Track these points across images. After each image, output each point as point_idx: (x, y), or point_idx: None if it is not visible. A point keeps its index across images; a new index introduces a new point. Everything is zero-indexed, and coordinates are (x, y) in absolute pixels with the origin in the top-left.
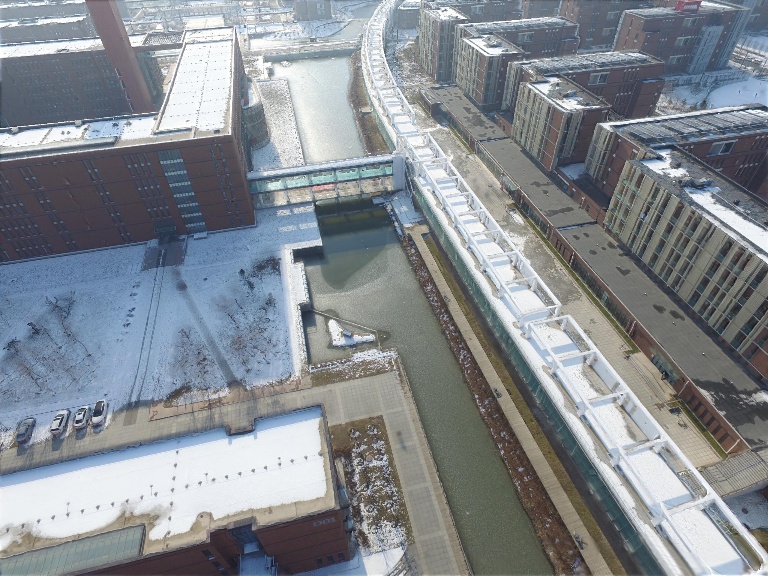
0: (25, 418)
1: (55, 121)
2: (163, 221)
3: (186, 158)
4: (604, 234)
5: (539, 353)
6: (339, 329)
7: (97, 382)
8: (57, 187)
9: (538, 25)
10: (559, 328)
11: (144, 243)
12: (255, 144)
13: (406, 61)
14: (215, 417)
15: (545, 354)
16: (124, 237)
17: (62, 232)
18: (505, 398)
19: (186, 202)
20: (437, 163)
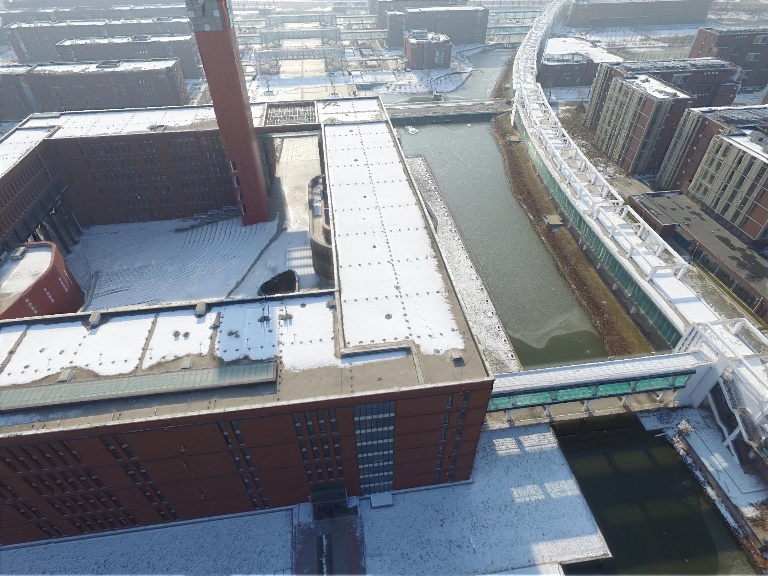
0: None
1: (136, 214)
2: (327, 483)
3: (401, 411)
4: None
5: None
6: None
7: None
8: (163, 455)
9: None
10: None
11: (287, 509)
12: None
13: (572, 137)
14: None
15: None
16: (256, 502)
17: (157, 503)
18: None
19: (374, 461)
20: None
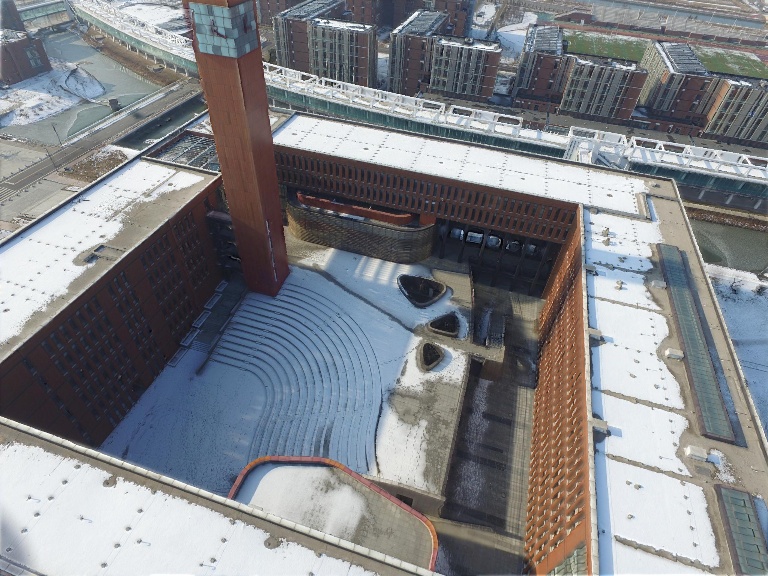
0: None
1: (118, 408)
2: None
3: None
4: None
5: None
6: None
7: None
8: None
9: None
10: None
11: None
12: None
13: None
14: None
15: None
16: None
17: None
18: None
19: None
20: None
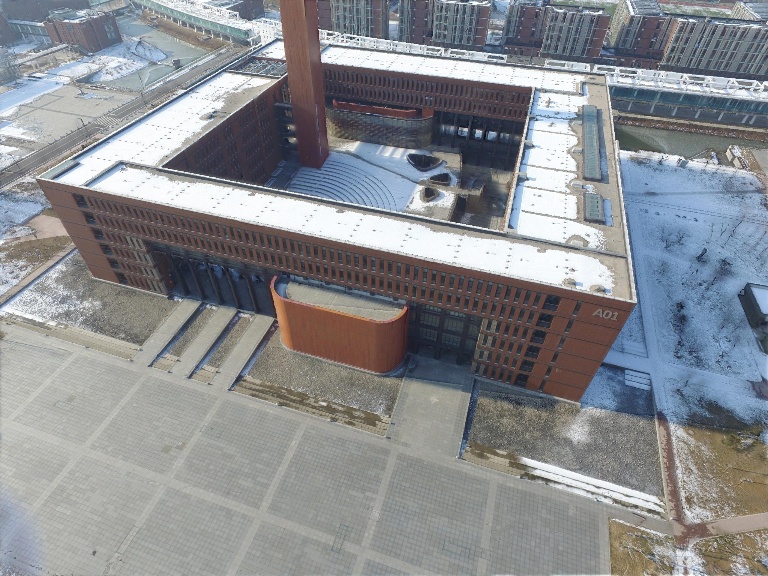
0: None
1: None
2: None
3: None
4: None
5: None
6: (704, 159)
7: (759, 236)
8: None
9: None
10: None
11: None
12: None
13: None
14: None
15: None
16: None
17: None
18: None
19: None
20: None
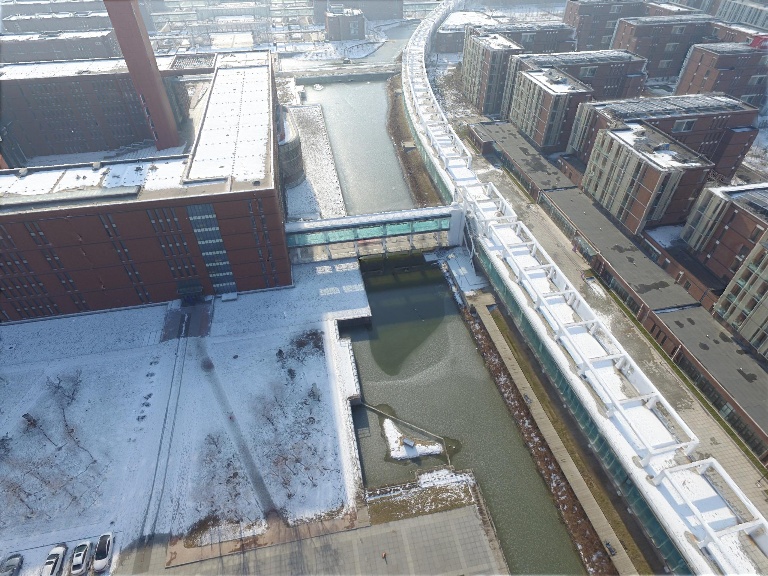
0: (10, 555)
1: (72, 147)
2: (188, 281)
3: (220, 213)
4: (713, 321)
5: (676, 510)
6: (397, 434)
7: (102, 503)
8: (68, 243)
9: (602, 59)
10: (694, 470)
11: (164, 304)
12: (289, 182)
13: (448, 89)
14: (249, 566)
15: (684, 512)
16: (142, 297)
17: (71, 291)
18: (621, 557)
19: (216, 261)
20: (507, 223)
